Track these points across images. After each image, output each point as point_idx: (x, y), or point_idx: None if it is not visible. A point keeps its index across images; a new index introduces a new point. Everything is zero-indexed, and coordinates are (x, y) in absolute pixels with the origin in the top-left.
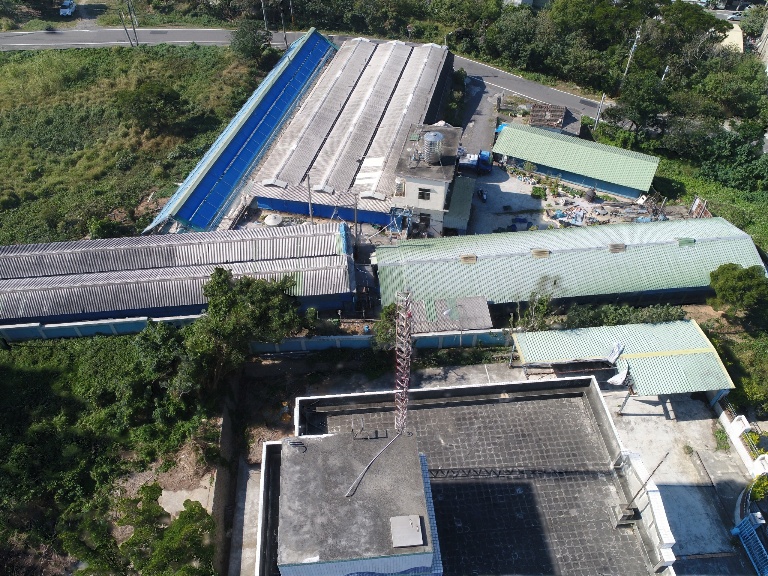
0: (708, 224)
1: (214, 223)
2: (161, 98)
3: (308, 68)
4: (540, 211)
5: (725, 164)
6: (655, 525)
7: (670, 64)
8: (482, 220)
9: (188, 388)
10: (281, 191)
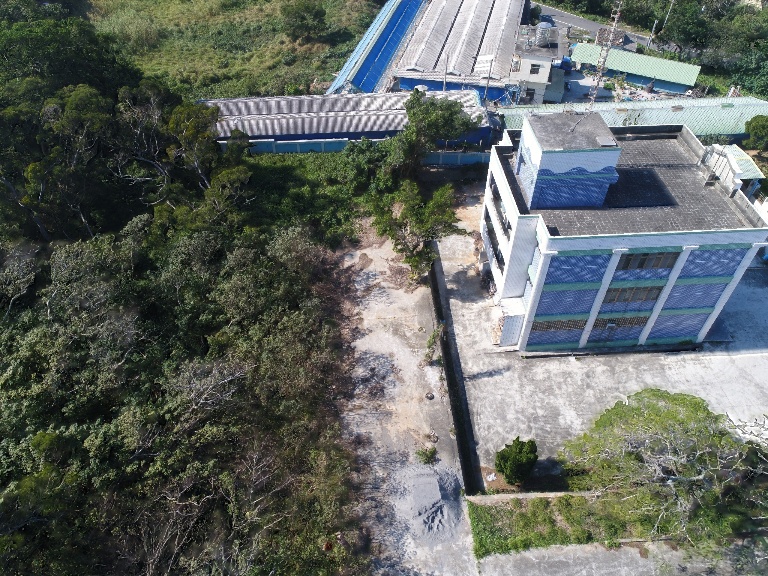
0: (742, 99)
1: (375, 92)
2: None
3: None
4: (612, 97)
5: (751, 76)
6: (731, 168)
7: (705, 8)
8: None
9: (401, 162)
10: (420, 74)
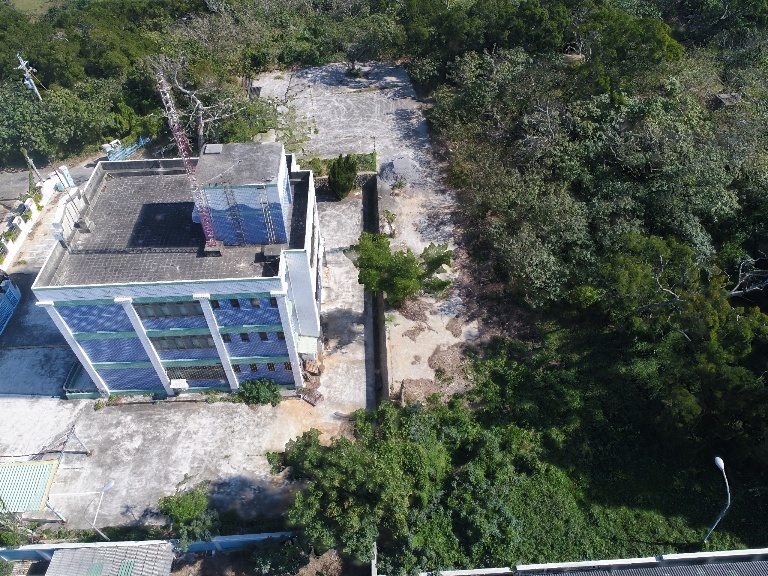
0: None
1: None
2: None
3: None
4: None
5: None
6: None
7: None
8: None
9: None
10: None
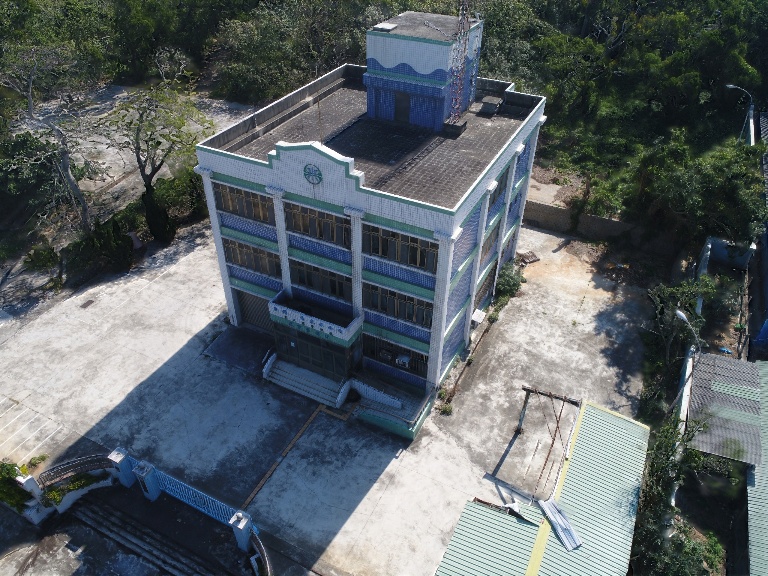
0: None
1: None
2: None
3: None
4: None
5: None
6: None
7: None
8: None
9: (634, 165)
10: None
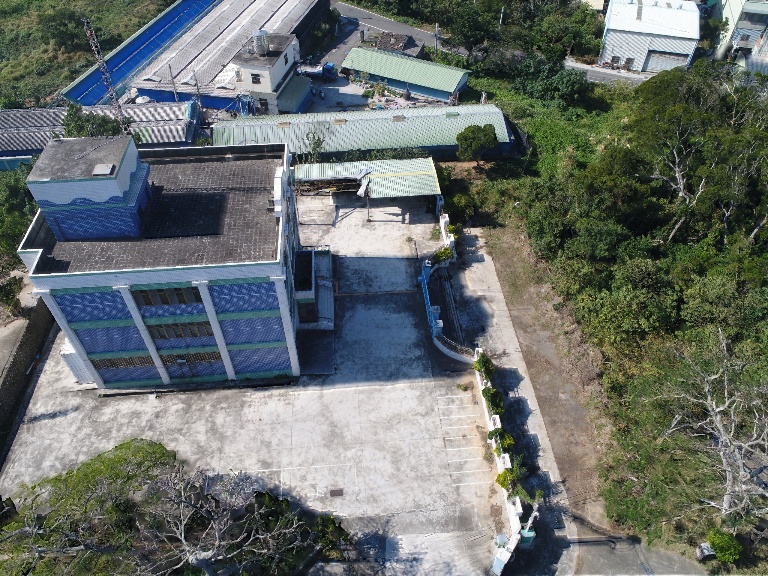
0: (478, 107)
1: (99, 104)
2: (75, 21)
3: (203, 4)
4: (365, 105)
5: (532, 80)
6: None
7: (513, 8)
8: (317, 111)
9: None
10: (156, 84)
